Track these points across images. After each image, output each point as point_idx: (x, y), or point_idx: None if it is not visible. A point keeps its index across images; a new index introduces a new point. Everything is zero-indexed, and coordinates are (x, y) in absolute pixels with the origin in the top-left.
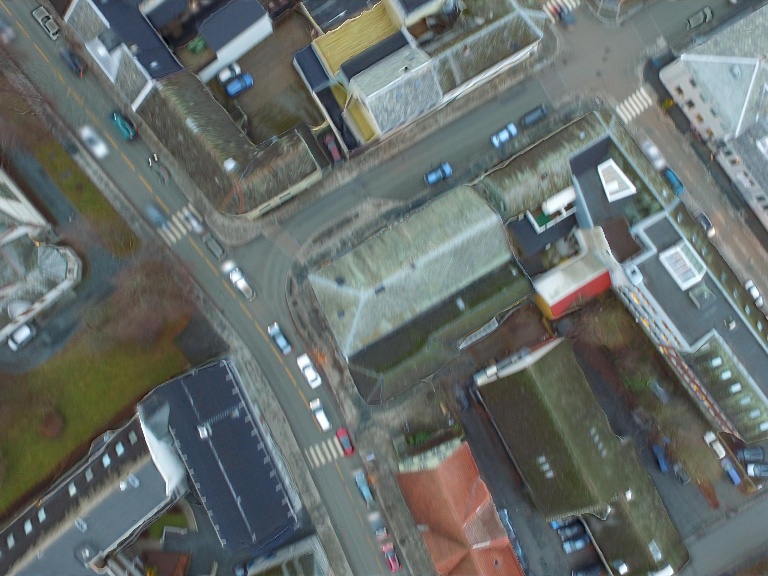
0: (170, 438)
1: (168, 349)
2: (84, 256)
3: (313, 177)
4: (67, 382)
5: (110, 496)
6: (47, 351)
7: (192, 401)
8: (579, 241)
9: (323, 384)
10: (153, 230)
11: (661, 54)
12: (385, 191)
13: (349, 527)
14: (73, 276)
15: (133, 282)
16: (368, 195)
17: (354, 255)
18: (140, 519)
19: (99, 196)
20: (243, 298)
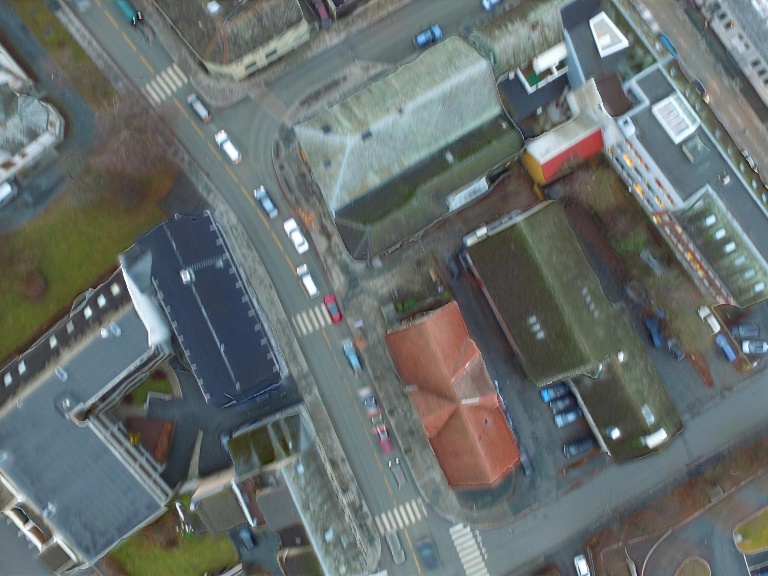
0: (153, 290)
1: (152, 212)
2: (66, 114)
3: (299, 31)
4: (49, 243)
5: (91, 344)
6: (29, 211)
7: (175, 245)
8: (571, 106)
9: (310, 250)
10: (137, 90)
11: None
12: (374, 54)
13: (337, 397)
14: (55, 132)
15: (116, 141)
16: (356, 58)
17: (341, 106)
18: (122, 371)
19: (82, 54)
20: (229, 161)
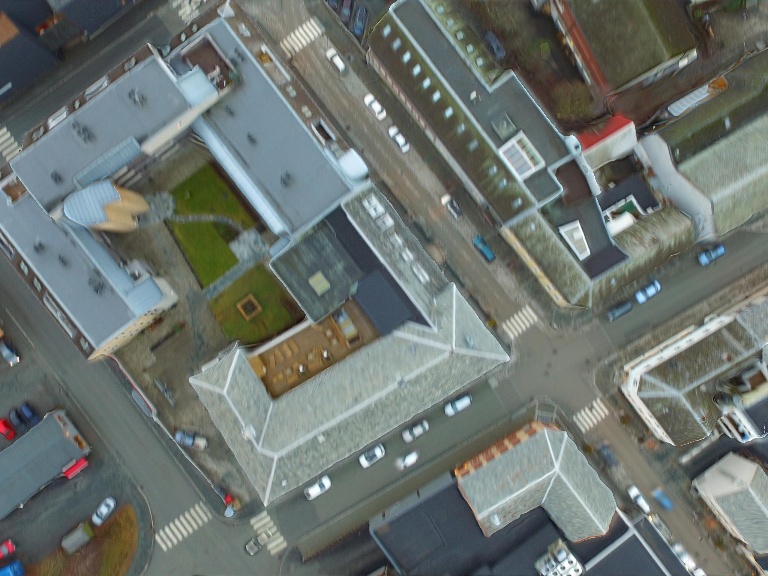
0: None
1: None
2: None
3: None
4: None
5: None
6: None
7: None
8: None
9: None
10: None
11: (494, 371)
12: (759, 240)
13: None
14: None
15: None
16: None
17: None
18: None
19: None
20: None
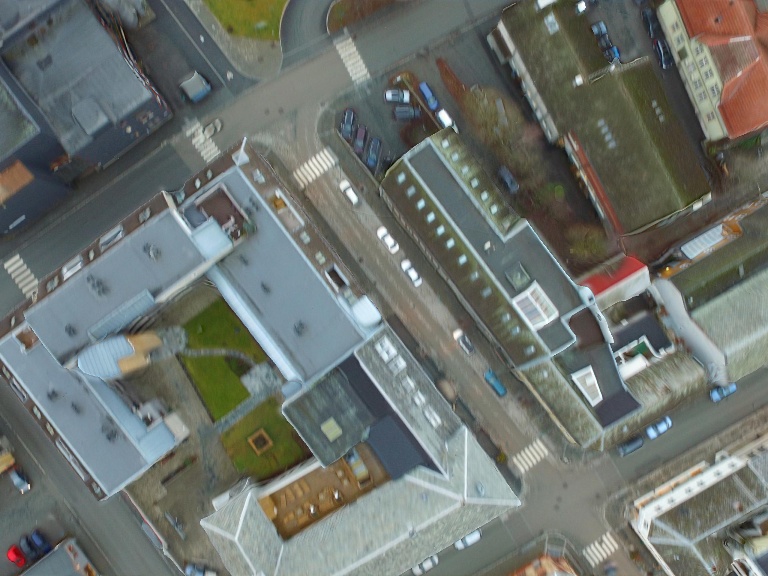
0: None
1: None
2: None
3: None
4: None
5: None
6: None
7: None
8: None
9: None
10: None
11: None
12: None
13: None
14: None
15: None
16: None
17: None
18: None
19: None
20: None
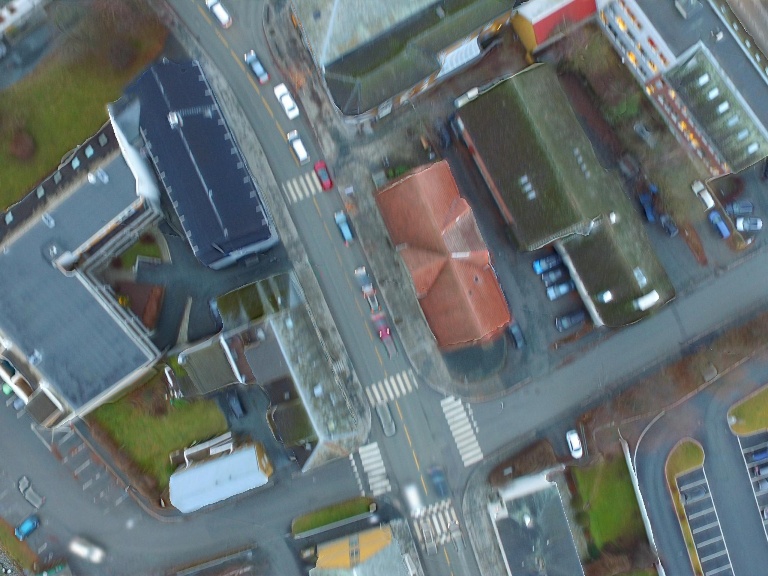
0: (141, 141)
1: None
2: None
3: None
4: (38, 104)
5: (78, 191)
6: (17, 72)
7: (162, 89)
8: None
9: (301, 116)
10: None
11: None
12: None
13: (327, 265)
14: None
15: None
16: None
17: None
18: (110, 220)
19: None
20: (219, 24)
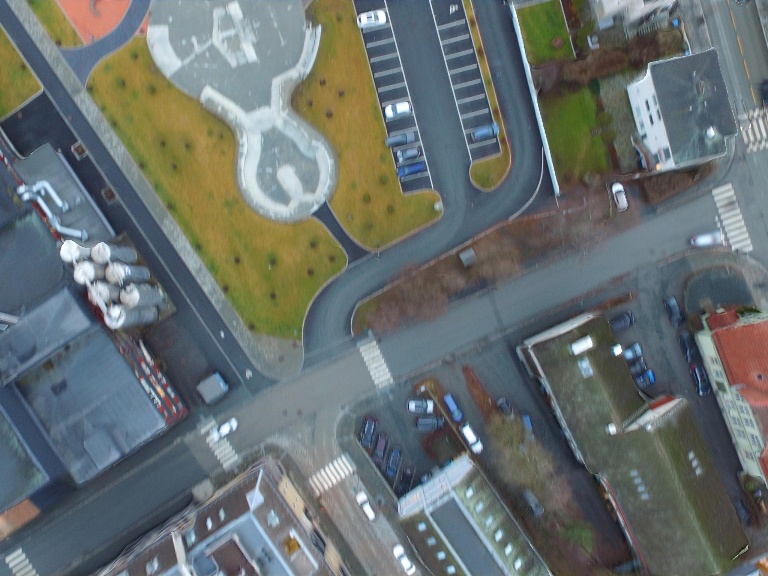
0: None
1: None
2: None
3: None
4: None
5: None
6: None
7: None
8: None
9: None
10: None
11: None
12: None
13: None
14: None
15: None
16: None
17: None
18: None
19: None
20: None
